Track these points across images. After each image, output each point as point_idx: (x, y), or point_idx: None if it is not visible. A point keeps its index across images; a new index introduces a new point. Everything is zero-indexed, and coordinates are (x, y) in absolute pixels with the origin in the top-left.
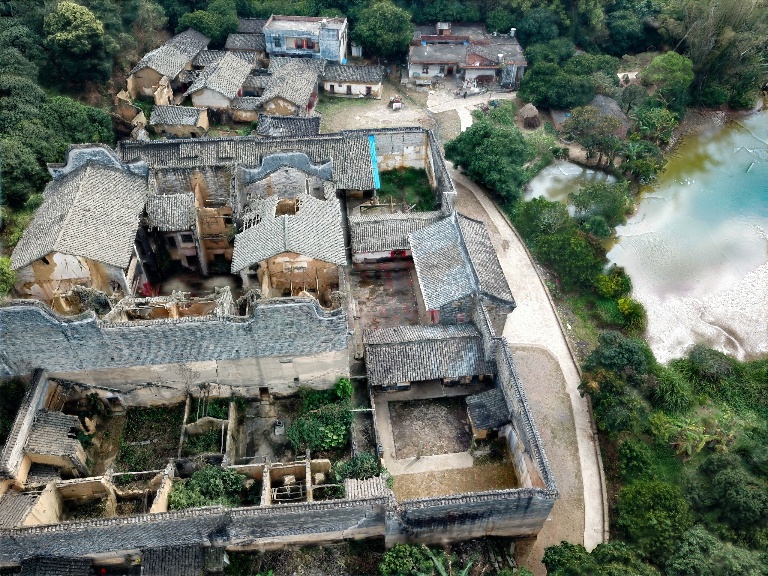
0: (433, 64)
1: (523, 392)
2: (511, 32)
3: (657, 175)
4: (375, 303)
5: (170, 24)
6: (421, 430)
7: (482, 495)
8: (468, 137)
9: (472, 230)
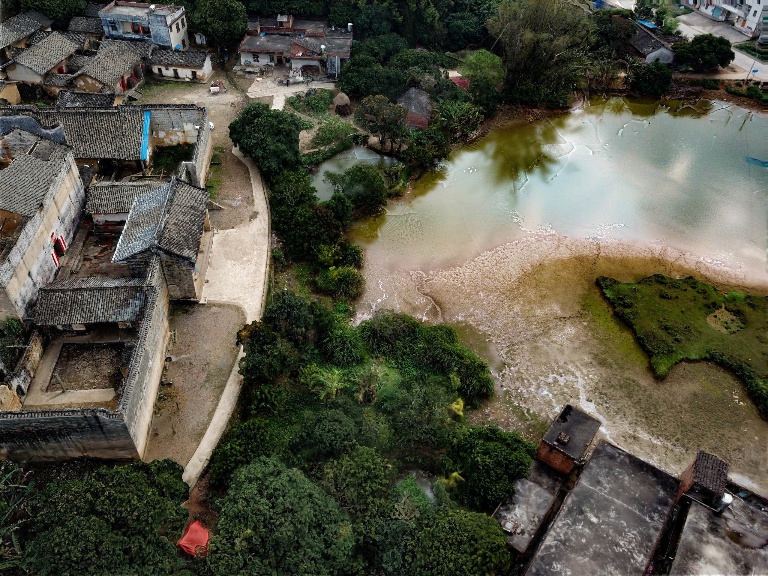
0: (260, 53)
1: (146, 331)
2: (348, 27)
3: (446, 163)
4: (100, 260)
5: (19, 5)
6: (82, 369)
7: (47, 411)
8: (242, 116)
9: (189, 195)
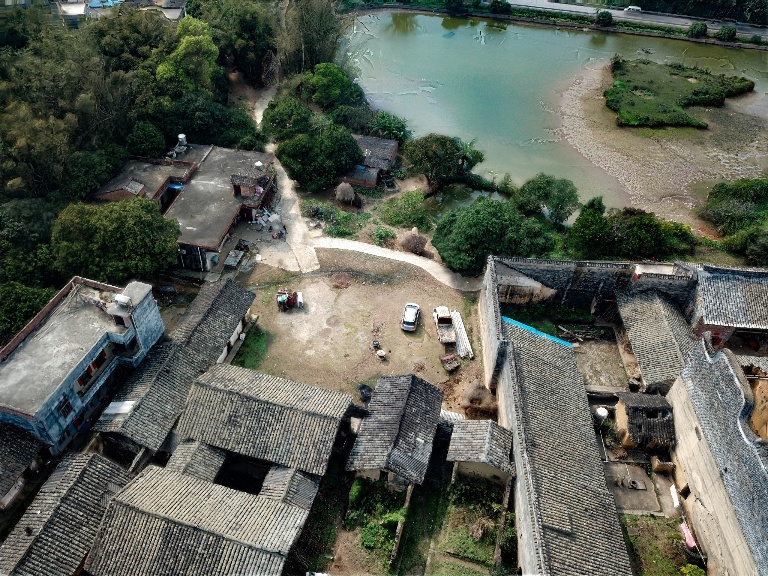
0: None
1: None
2: (182, 141)
3: None
4: None
5: None
6: None
7: None
8: (493, 234)
9: None
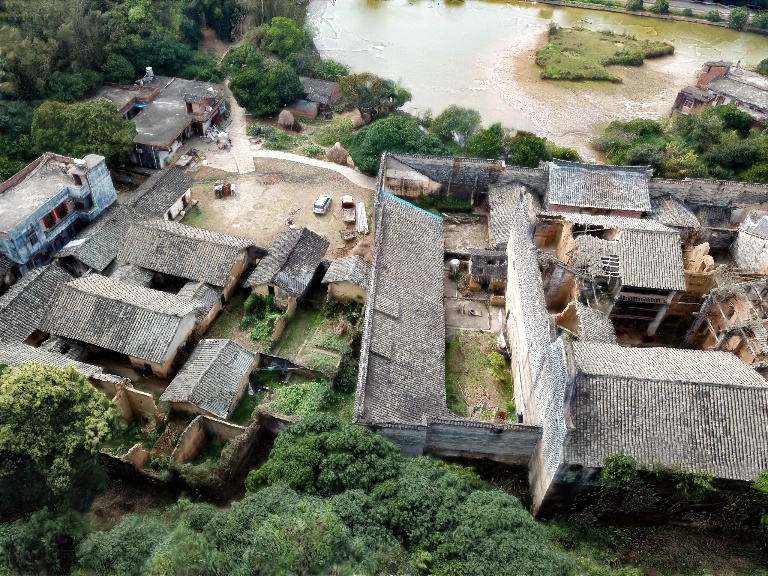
0: None
1: None
2: (149, 72)
3: None
4: None
5: None
6: None
7: None
8: (393, 140)
9: None
